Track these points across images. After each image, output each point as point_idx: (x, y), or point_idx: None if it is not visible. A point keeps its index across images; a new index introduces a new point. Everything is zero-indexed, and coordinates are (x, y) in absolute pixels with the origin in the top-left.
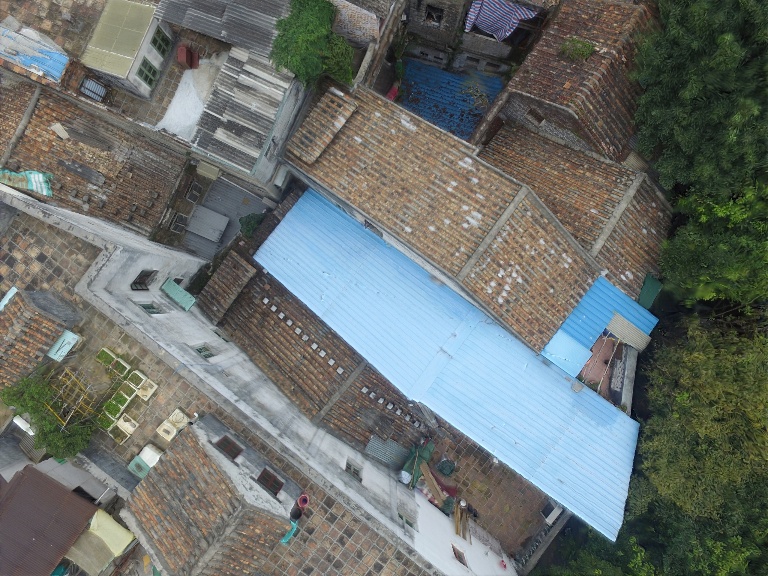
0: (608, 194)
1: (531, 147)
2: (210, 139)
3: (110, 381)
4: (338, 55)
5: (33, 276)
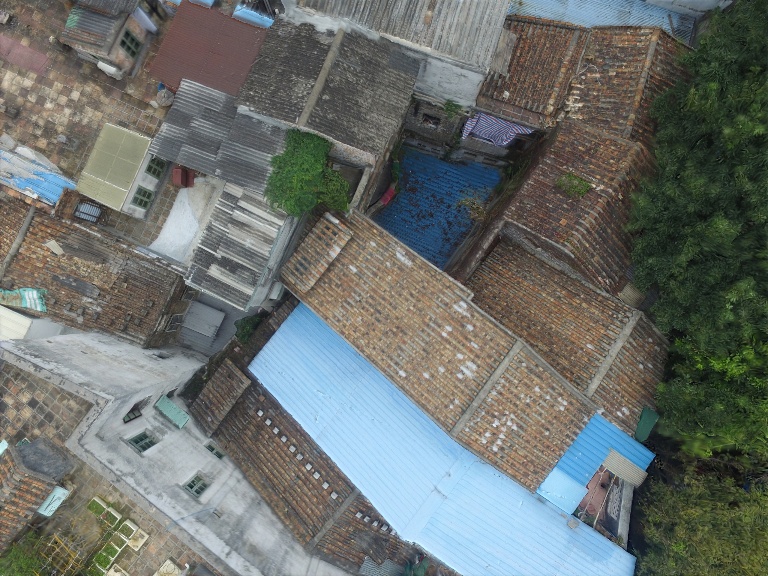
0: (604, 330)
1: (527, 269)
2: (204, 275)
3: (101, 530)
4: (333, 191)
5: (24, 422)
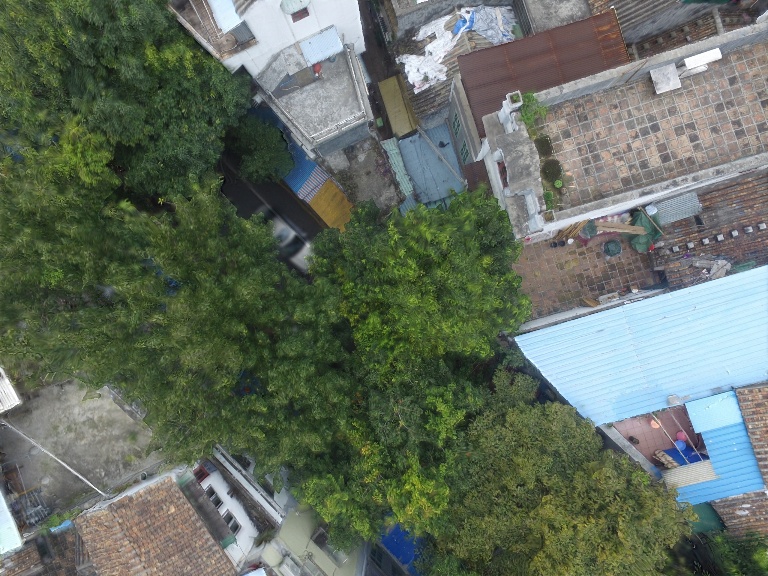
0: None
1: None
2: None
3: None
4: None
5: None
